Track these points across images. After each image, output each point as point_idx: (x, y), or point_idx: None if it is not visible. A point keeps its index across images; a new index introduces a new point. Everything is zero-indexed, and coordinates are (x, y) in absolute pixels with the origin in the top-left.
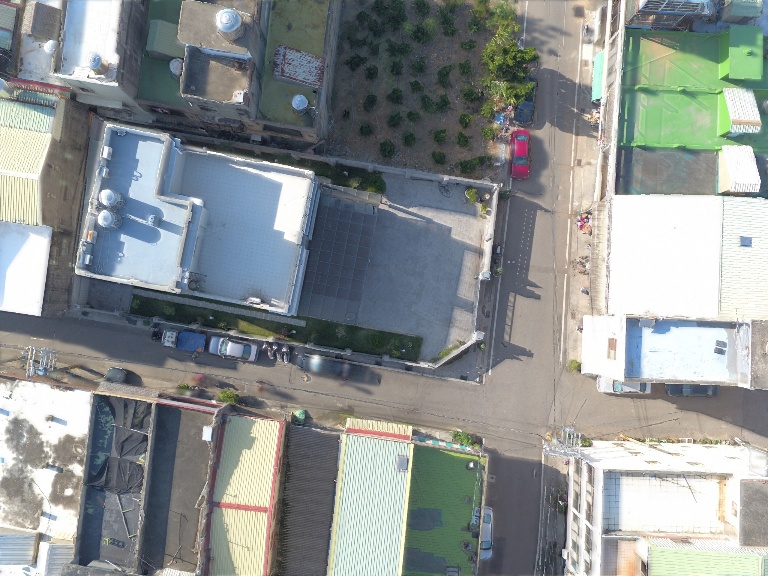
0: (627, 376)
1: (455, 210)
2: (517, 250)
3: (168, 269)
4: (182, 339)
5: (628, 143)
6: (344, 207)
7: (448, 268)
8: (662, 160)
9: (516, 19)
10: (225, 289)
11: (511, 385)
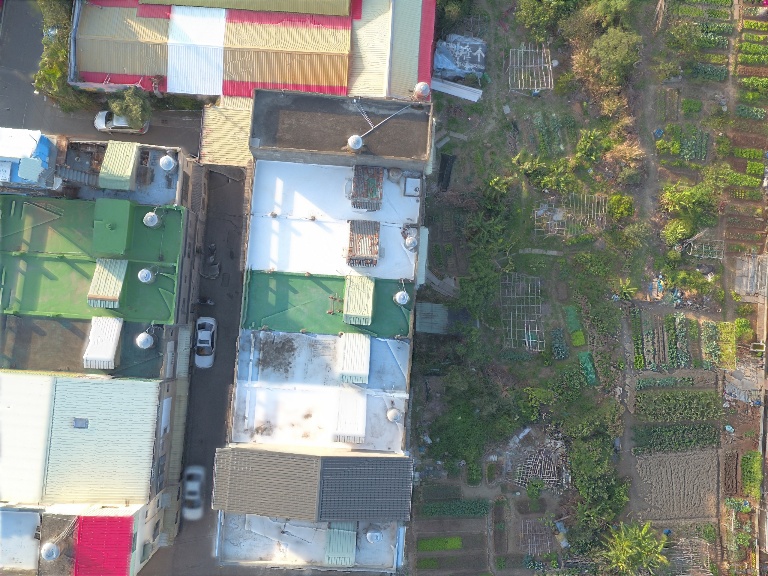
0: None
1: None
2: None
3: None
4: None
5: (1, 310)
6: None
7: None
8: (37, 328)
9: None
10: None
11: None
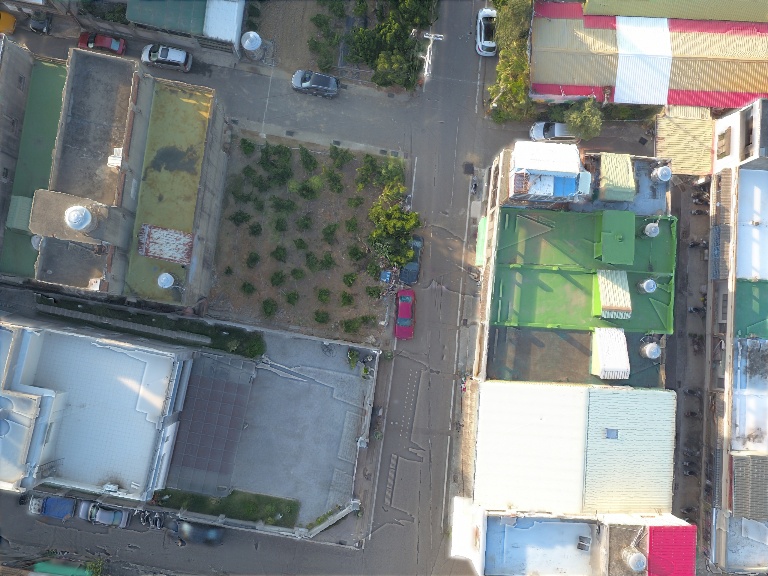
0: (488, 573)
1: (338, 370)
2: (400, 411)
3: (16, 463)
4: (50, 505)
5: (502, 322)
6: (219, 374)
7: (329, 430)
8: (536, 340)
9: (402, 179)
10: (83, 472)
11: (391, 550)
